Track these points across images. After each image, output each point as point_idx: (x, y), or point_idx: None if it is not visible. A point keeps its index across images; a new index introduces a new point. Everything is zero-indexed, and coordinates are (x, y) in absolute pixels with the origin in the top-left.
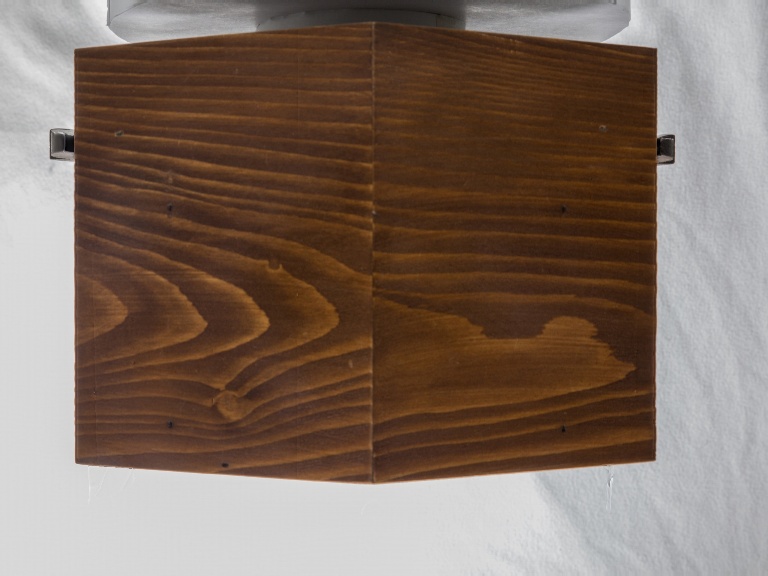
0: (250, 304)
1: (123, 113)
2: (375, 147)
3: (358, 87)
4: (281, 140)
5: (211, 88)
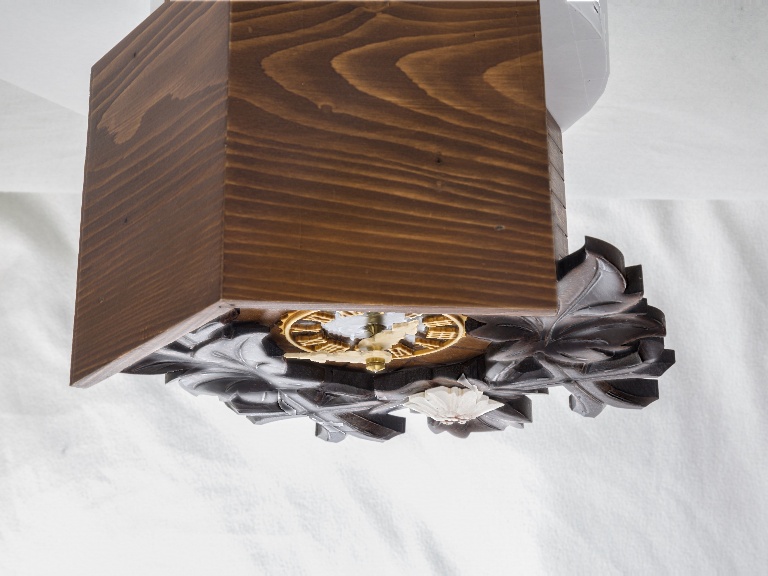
0: (351, 78)
1: (496, 246)
2: (223, 197)
3: (238, 247)
4: (319, 209)
5: (395, 259)
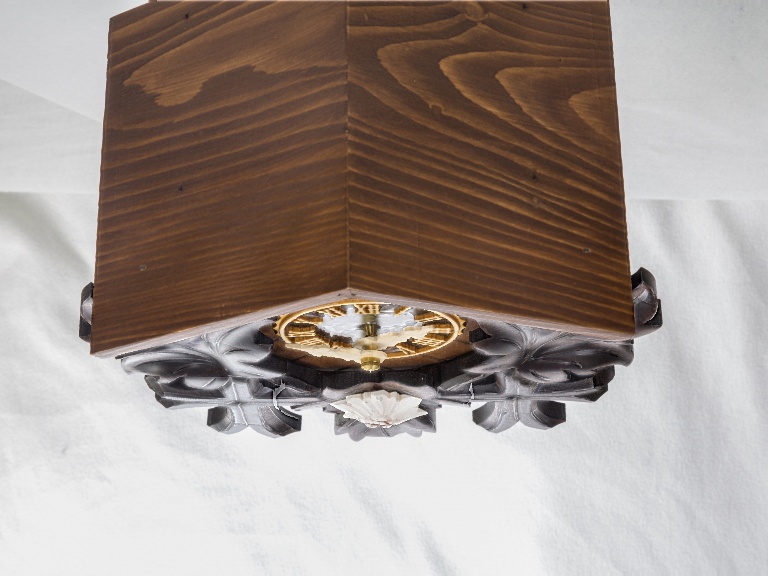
0: (457, 83)
1: (584, 267)
2: (346, 184)
3: (362, 236)
4: (433, 209)
5: (501, 268)
